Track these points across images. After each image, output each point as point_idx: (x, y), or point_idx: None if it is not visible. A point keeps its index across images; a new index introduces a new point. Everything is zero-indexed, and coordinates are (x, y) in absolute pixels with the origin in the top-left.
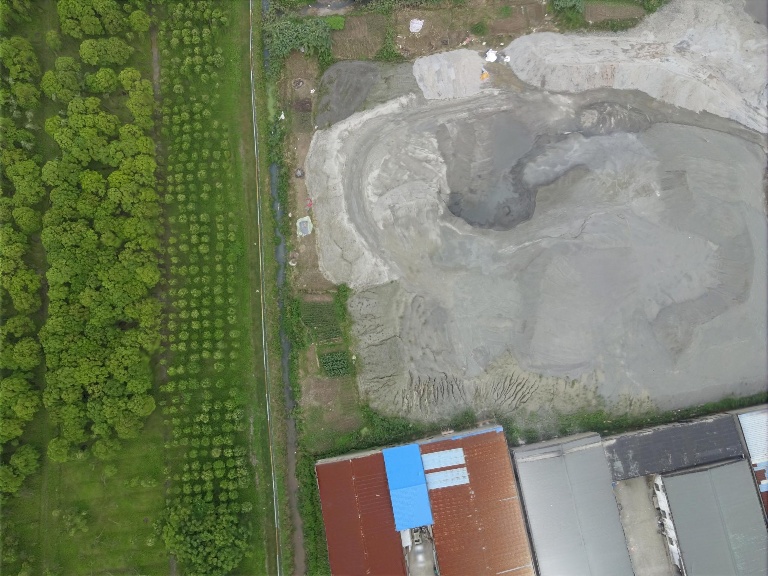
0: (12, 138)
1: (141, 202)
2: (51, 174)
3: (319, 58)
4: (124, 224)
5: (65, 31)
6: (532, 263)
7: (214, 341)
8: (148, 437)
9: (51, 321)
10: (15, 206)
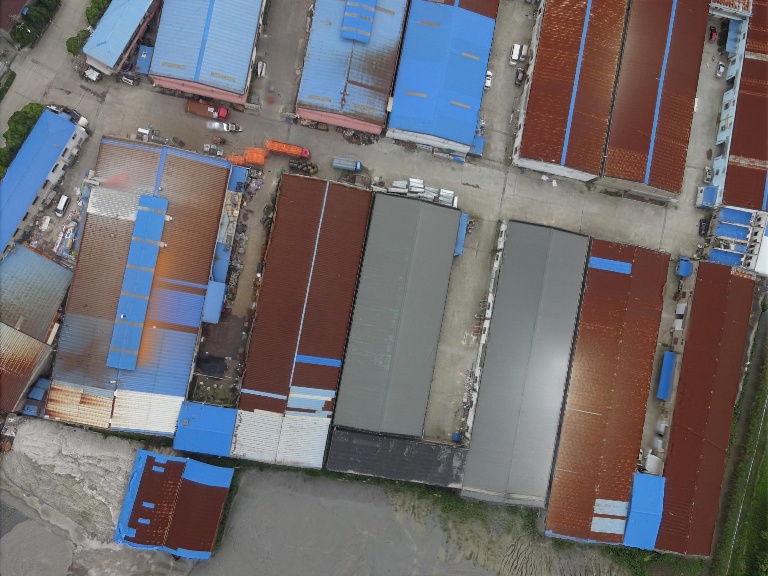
0: None
1: None
2: None
3: None
4: None
5: None
6: None
7: None
8: None
9: None
10: None
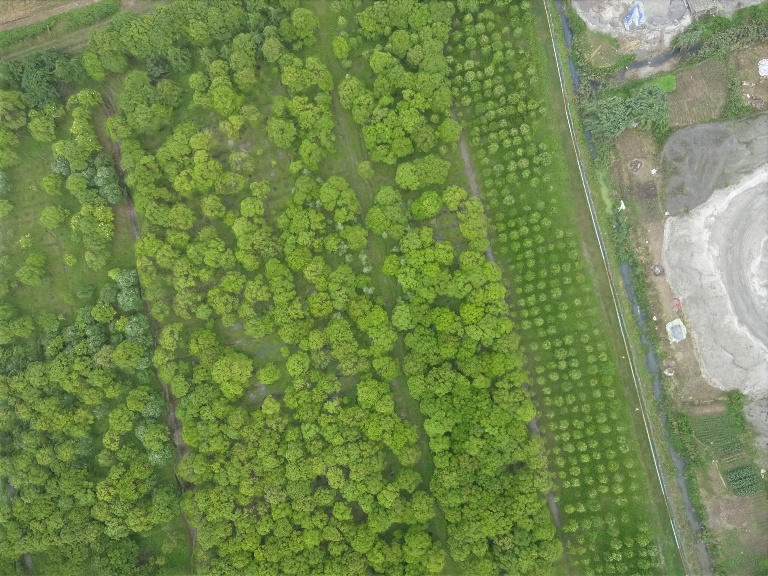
0: (353, 285)
1: (503, 336)
2: (406, 321)
3: (655, 131)
4: (493, 364)
5: (377, 159)
6: None
7: (610, 474)
8: (553, 575)
9: (447, 477)
10: (375, 358)
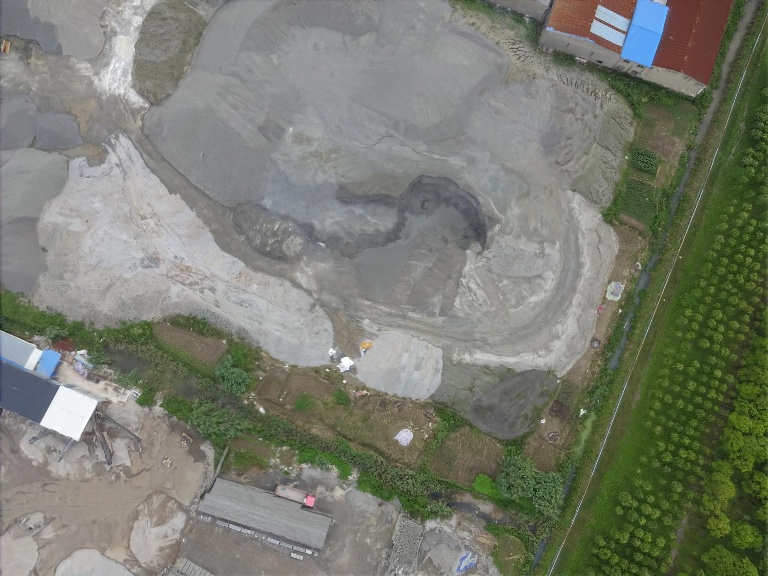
0: None
1: (760, 383)
2: None
3: None
4: None
5: None
6: (443, 138)
7: (742, 229)
8: None
9: None
10: None
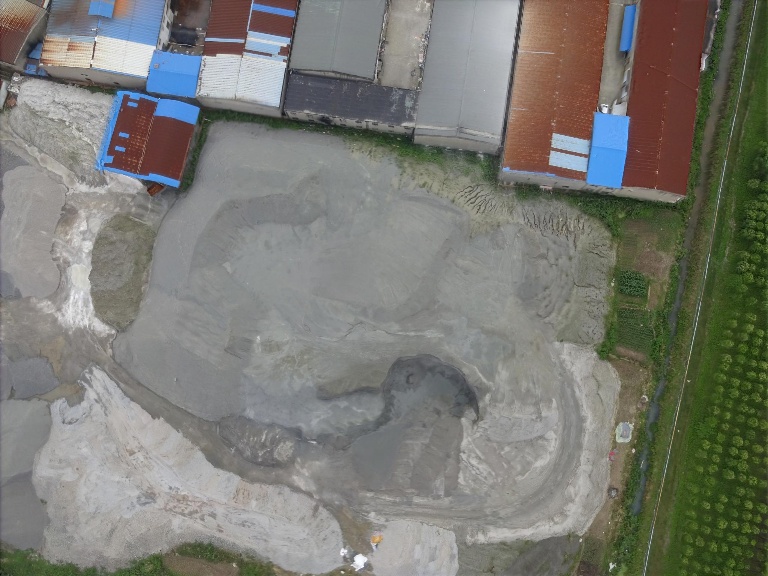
0: None
1: None
2: None
3: None
4: None
5: None
6: (415, 313)
7: (750, 343)
8: None
9: None
10: None
